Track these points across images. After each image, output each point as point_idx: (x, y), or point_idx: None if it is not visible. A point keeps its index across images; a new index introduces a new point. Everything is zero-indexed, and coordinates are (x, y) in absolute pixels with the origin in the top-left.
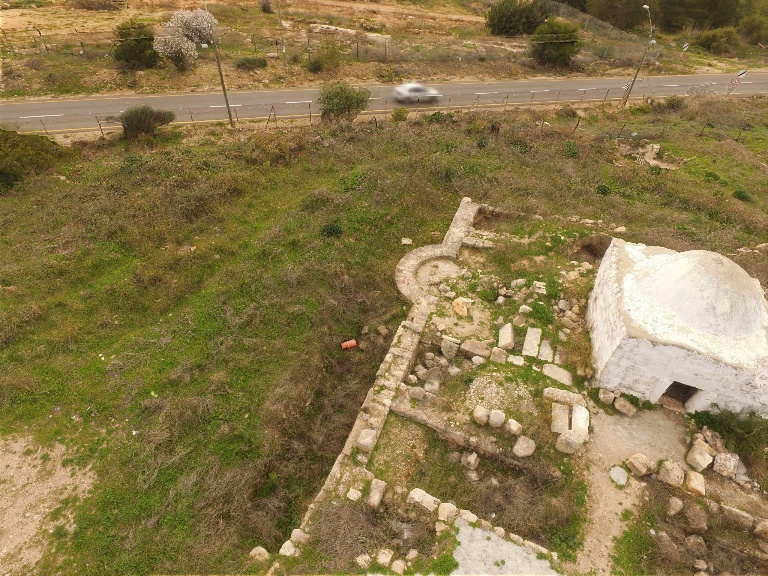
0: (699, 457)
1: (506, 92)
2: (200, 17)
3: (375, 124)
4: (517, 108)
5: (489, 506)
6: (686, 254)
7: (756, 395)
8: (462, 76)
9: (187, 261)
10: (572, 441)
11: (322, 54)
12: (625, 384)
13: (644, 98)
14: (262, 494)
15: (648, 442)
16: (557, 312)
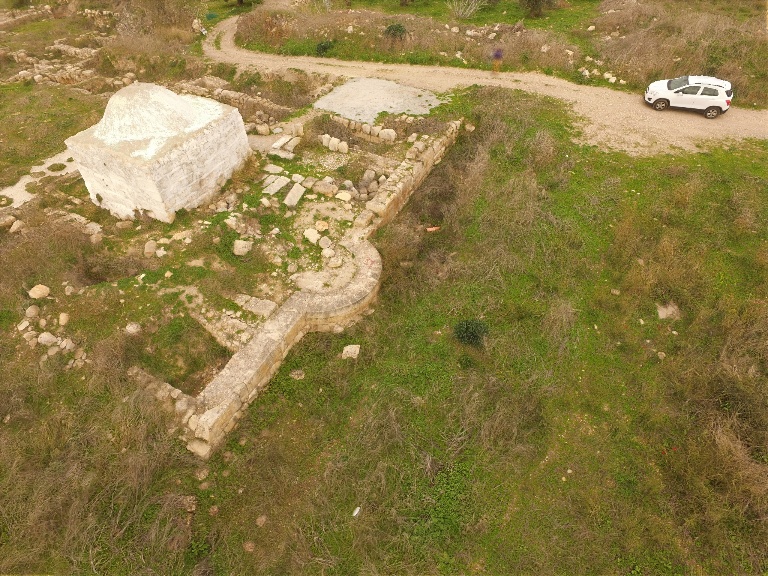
0: None
1: None
2: None
3: None
4: None
5: None
6: (145, 99)
7: None
8: None
9: None
10: None
11: None
12: None
13: None
14: None
15: None
16: None
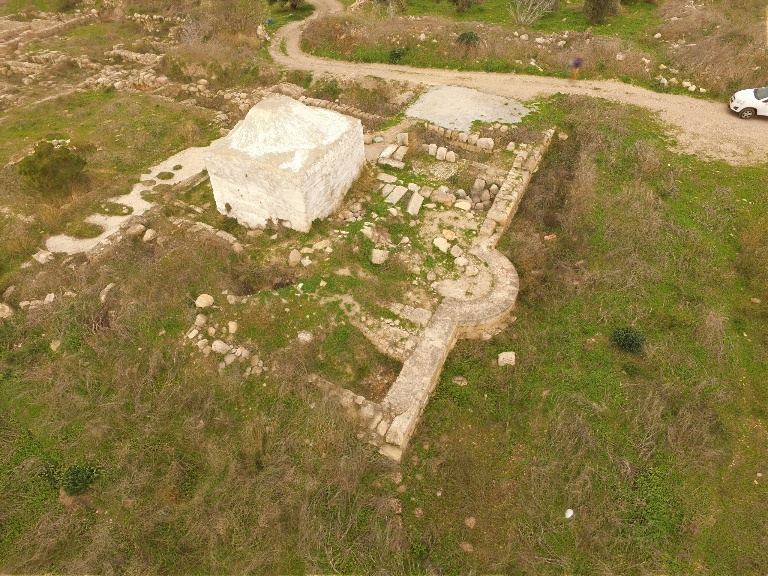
0: None
1: None
2: None
3: None
4: None
5: None
6: (288, 113)
7: None
8: None
9: None
10: None
11: None
12: None
13: None
14: None
15: None
16: None
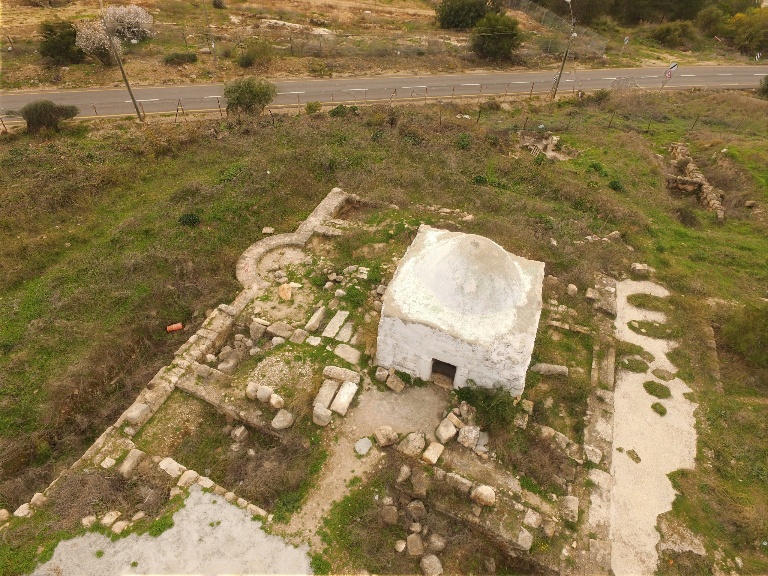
0: (443, 429)
1: (435, 86)
2: (133, 13)
3: (276, 117)
4: (439, 101)
5: (239, 474)
6: (455, 238)
7: (499, 371)
8: (398, 70)
9: (35, 248)
10: (319, 413)
11: (251, 49)
12: (397, 362)
13: (575, 91)
14: (37, 464)
15: (406, 416)
16: (374, 296)
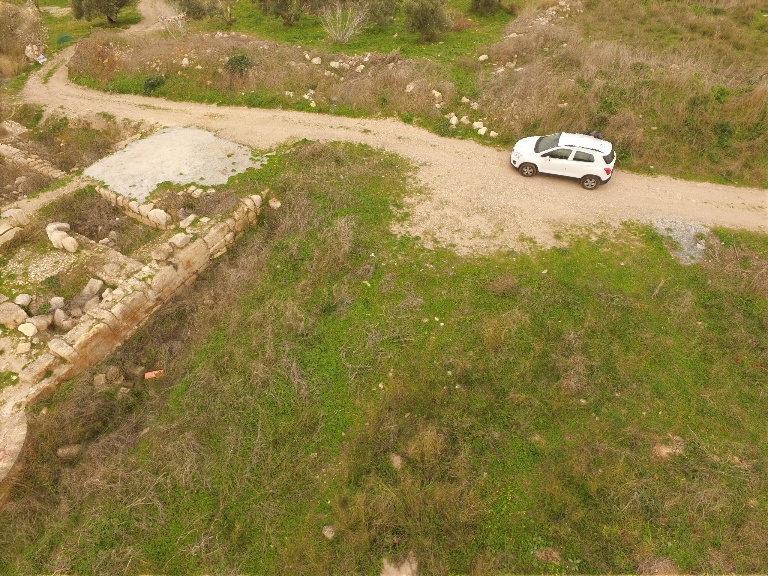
0: None
1: None
2: None
3: None
4: None
5: None
6: None
7: None
8: None
9: None
10: None
11: None
12: None
13: None
14: None
15: None
16: None
